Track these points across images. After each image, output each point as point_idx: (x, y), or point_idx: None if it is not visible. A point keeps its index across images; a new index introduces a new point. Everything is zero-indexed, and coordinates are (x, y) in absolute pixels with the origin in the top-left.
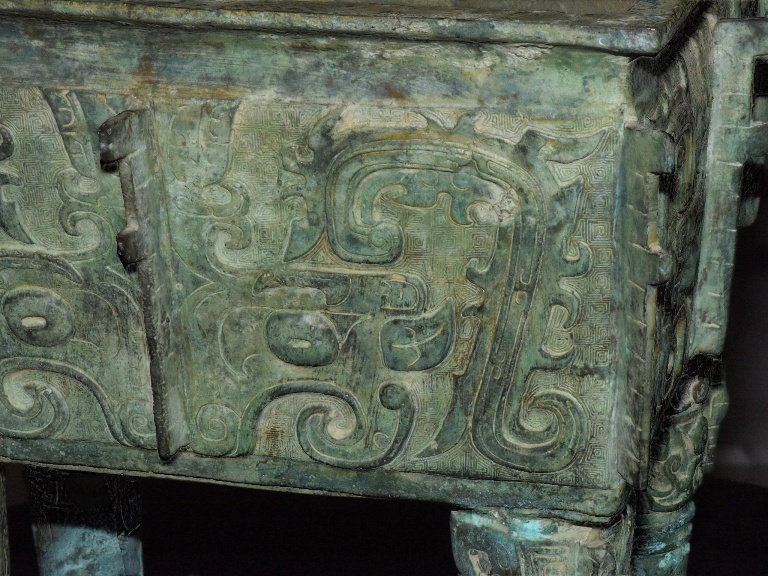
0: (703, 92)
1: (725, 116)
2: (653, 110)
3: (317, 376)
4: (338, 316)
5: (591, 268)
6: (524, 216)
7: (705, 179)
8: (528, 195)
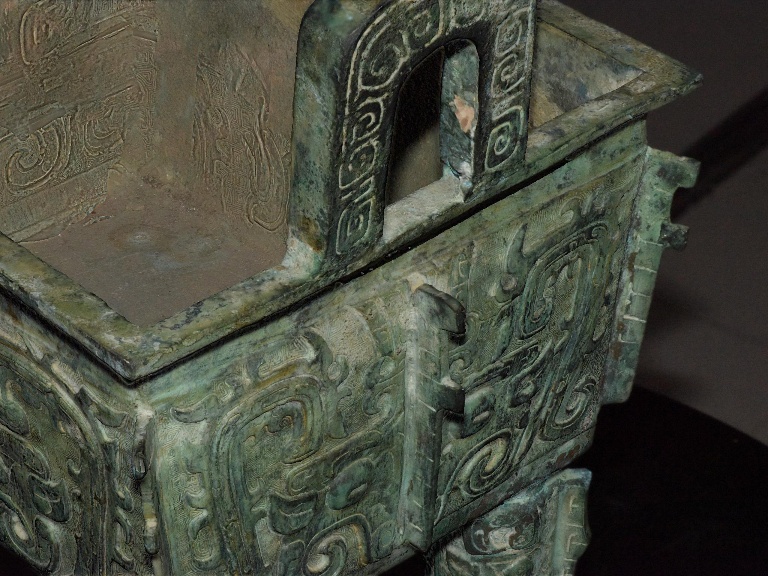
0: (377, 350)
1: (423, 366)
2: (196, 400)
3: (1, 487)
4: (2, 454)
5: (134, 509)
6: (88, 449)
7: (402, 412)
8: (86, 436)
